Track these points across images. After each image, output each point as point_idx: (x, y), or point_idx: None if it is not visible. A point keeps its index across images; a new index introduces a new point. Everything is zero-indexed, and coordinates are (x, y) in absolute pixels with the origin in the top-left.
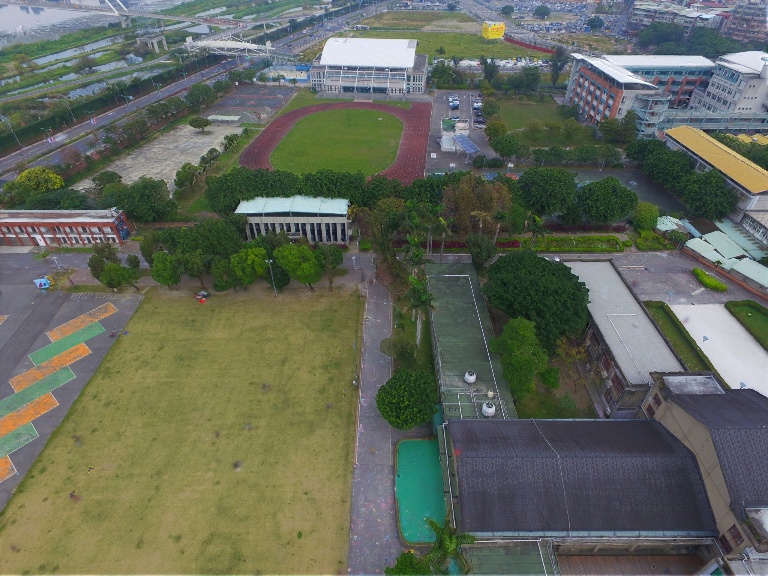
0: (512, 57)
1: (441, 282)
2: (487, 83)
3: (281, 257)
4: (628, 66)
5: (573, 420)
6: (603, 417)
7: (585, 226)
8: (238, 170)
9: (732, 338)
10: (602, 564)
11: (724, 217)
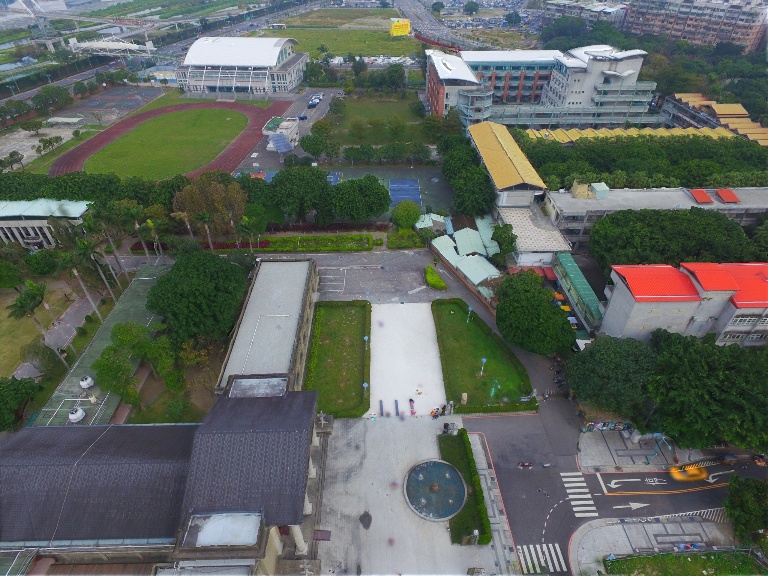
0: None
1: (143, 285)
2: (349, 81)
3: None
4: (478, 62)
5: (152, 425)
6: None
7: (347, 225)
8: None
9: (416, 337)
10: (105, 573)
11: (488, 213)
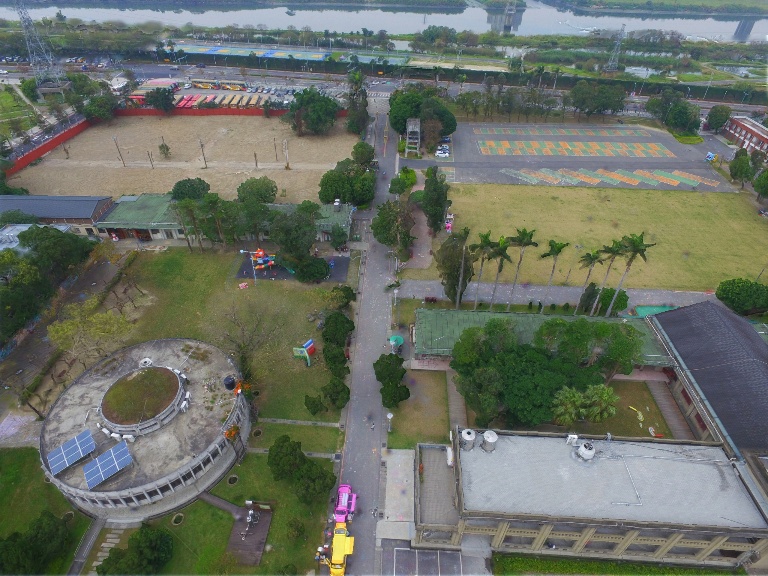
0: None
1: None
2: None
3: None
4: None
5: None
6: None
7: None
8: None
9: None
10: (678, 417)
11: None
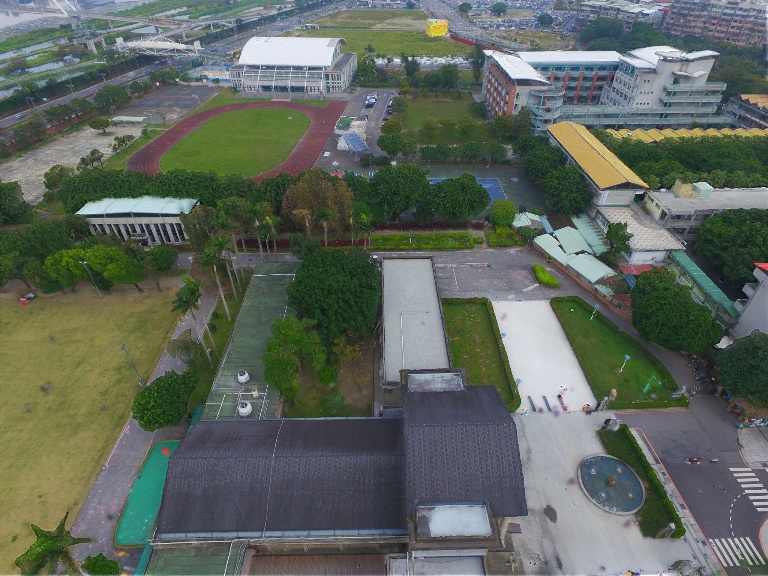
0: (448, 54)
1: (264, 281)
2: (404, 81)
3: (87, 258)
4: (538, 62)
5: (324, 419)
6: (377, 415)
7: (443, 223)
8: (89, 171)
9: (544, 334)
10: (308, 564)
11: (583, 213)
